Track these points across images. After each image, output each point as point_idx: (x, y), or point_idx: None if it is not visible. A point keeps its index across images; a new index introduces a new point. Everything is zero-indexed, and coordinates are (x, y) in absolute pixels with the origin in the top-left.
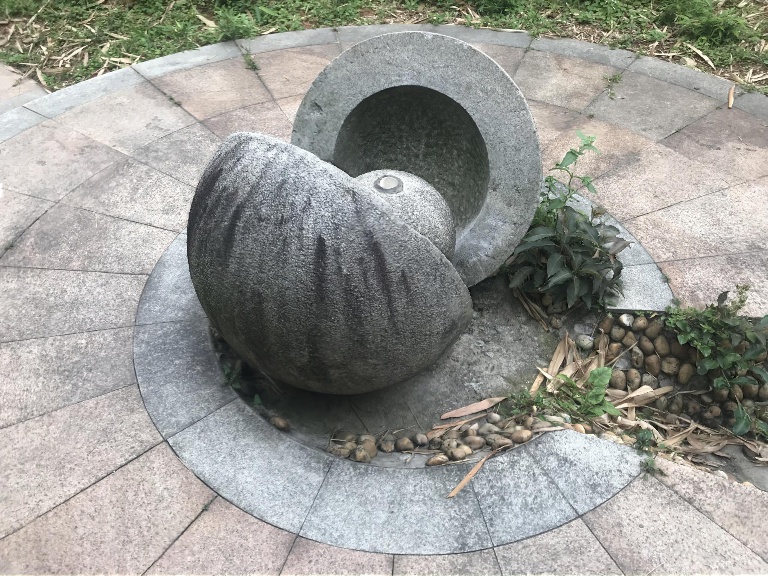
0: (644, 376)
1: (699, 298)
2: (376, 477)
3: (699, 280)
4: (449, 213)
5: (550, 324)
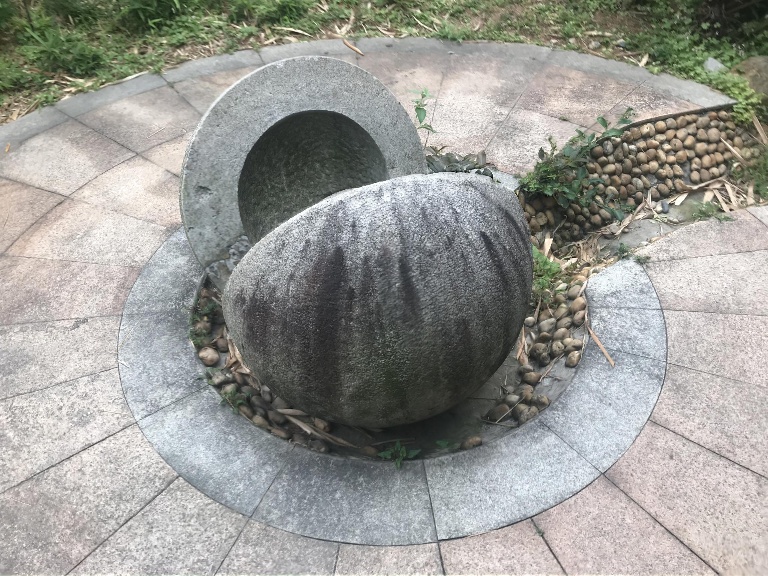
0: (537, 236)
1: (521, 166)
2: (572, 400)
3: (506, 157)
4: None
5: None
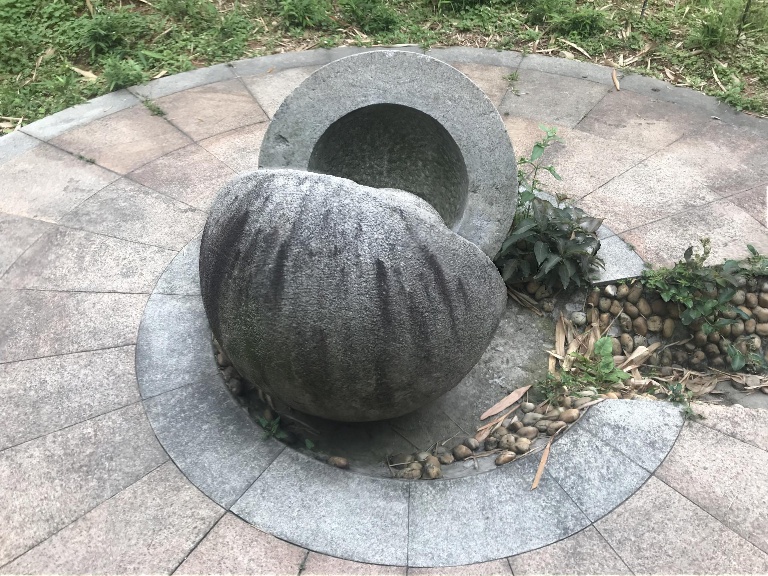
0: (635, 338)
1: (664, 258)
2: (457, 489)
3: (658, 243)
4: (443, 221)
5: (542, 309)
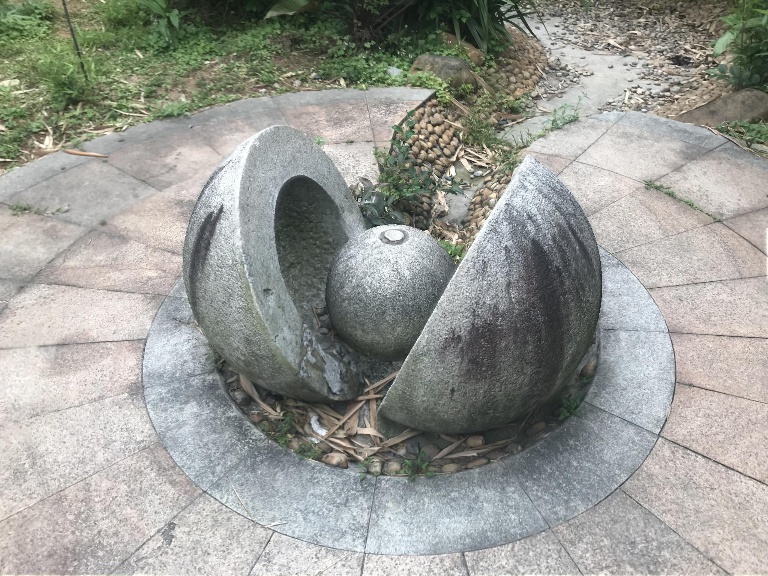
0: None
1: None
2: None
3: (349, 184)
4: None
5: None
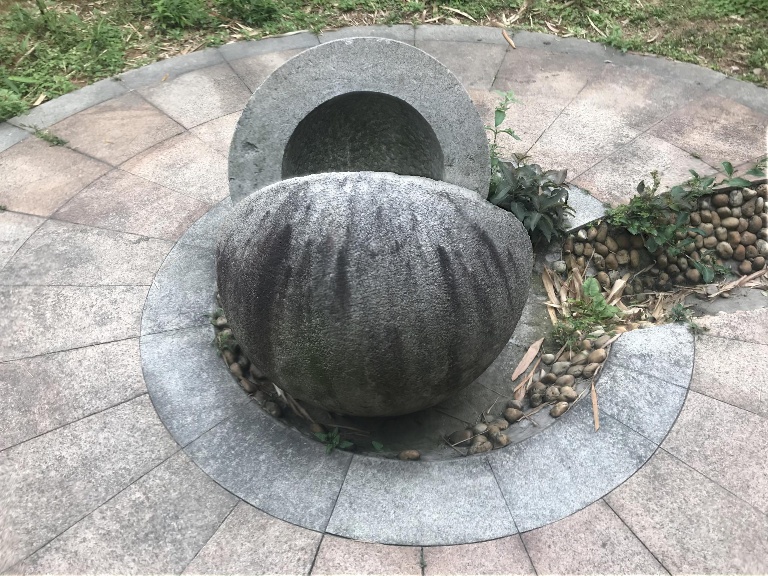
0: (610, 274)
1: (618, 196)
2: (531, 449)
3: (606, 183)
4: None
5: None
